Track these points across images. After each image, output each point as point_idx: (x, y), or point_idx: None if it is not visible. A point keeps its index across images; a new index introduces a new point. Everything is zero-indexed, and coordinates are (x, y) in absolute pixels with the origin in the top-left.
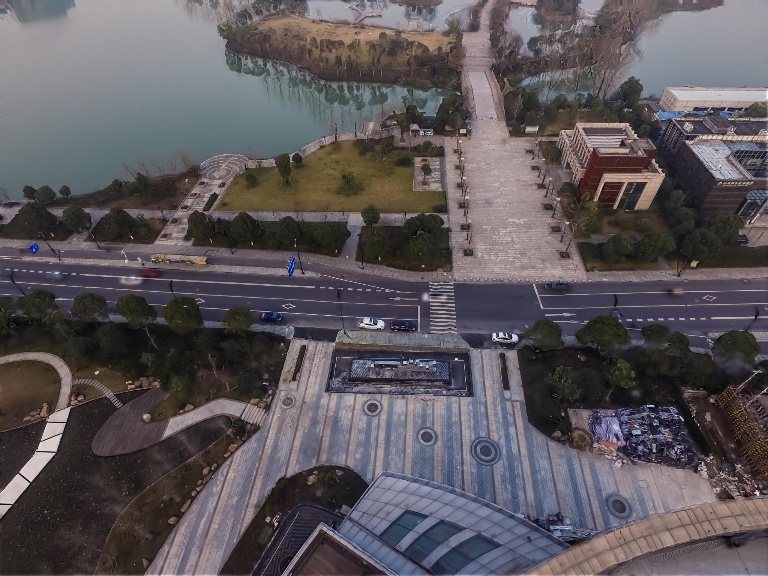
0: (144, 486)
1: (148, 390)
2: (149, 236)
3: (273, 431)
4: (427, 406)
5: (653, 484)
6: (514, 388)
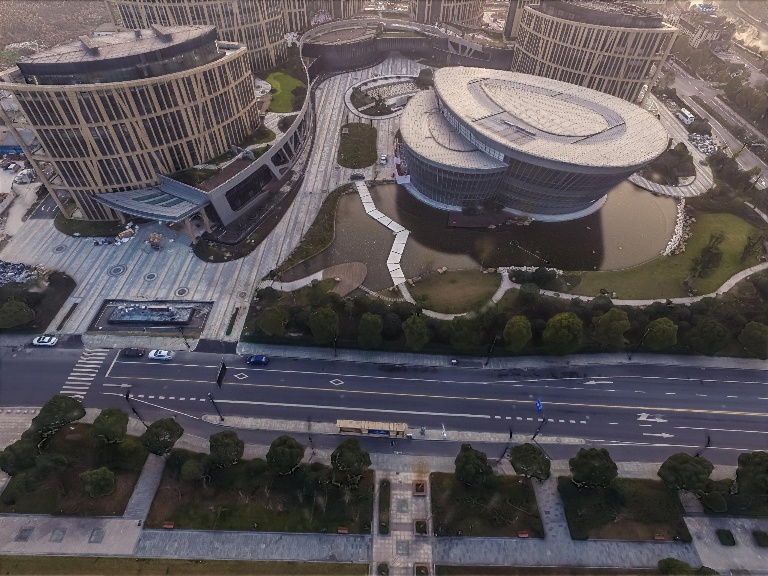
0: (325, 252)
1: (345, 296)
2: (441, 485)
3: (252, 278)
4: (142, 293)
5: (30, 257)
6: (70, 305)
